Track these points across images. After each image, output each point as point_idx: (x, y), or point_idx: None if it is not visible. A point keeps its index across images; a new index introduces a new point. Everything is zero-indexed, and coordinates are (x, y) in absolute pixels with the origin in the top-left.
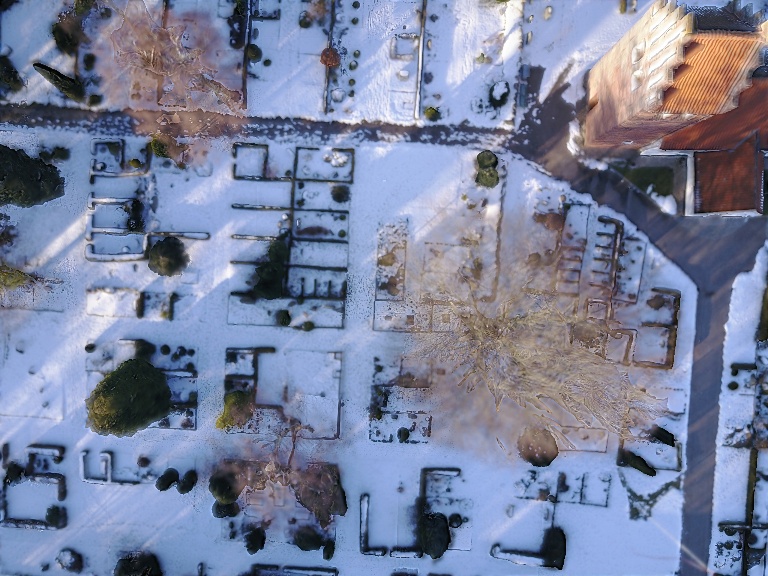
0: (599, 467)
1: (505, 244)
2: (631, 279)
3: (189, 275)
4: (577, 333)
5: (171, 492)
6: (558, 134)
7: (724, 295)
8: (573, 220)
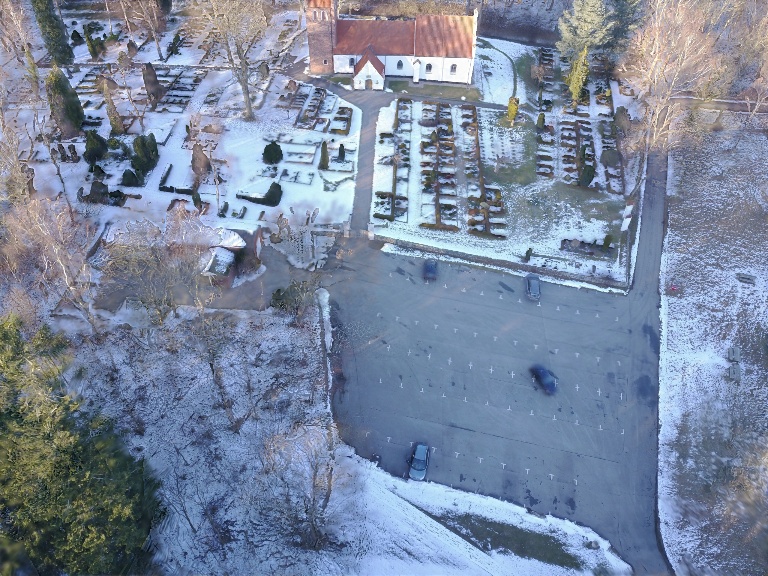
0: (308, 170)
1: (270, 95)
2: (329, 106)
3: (115, 97)
4: (300, 120)
5: (62, 165)
6: (300, 70)
7: (375, 113)
8: (303, 90)
